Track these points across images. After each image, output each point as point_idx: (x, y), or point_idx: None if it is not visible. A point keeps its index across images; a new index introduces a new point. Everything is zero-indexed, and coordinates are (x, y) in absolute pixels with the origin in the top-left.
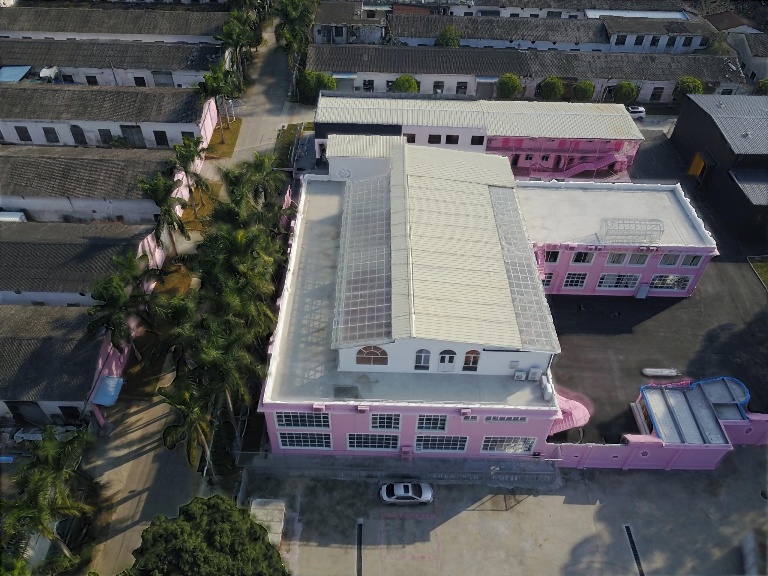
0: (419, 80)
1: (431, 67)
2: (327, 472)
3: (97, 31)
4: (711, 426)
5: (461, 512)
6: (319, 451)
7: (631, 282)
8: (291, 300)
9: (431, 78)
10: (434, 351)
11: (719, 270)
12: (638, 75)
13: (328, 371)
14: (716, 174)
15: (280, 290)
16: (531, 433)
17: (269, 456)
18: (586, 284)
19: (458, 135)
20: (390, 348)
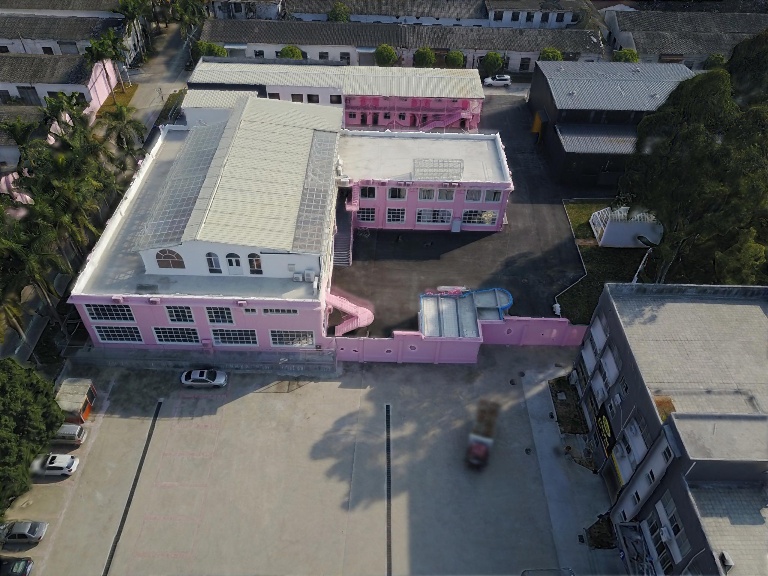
0: (305, 51)
1: (316, 39)
2: (139, 362)
3: (15, 7)
4: (470, 325)
5: (248, 394)
6: (134, 345)
7: (446, 217)
8: (122, 222)
9: (316, 49)
10: (220, 254)
11: (534, 210)
12: (506, 46)
13: (136, 274)
14: (549, 129)
15: (111, 212)
16: (308, 326)
17: (92, 350)
18: (406, 219)
19: (318, 94)
20: (182, 251)
